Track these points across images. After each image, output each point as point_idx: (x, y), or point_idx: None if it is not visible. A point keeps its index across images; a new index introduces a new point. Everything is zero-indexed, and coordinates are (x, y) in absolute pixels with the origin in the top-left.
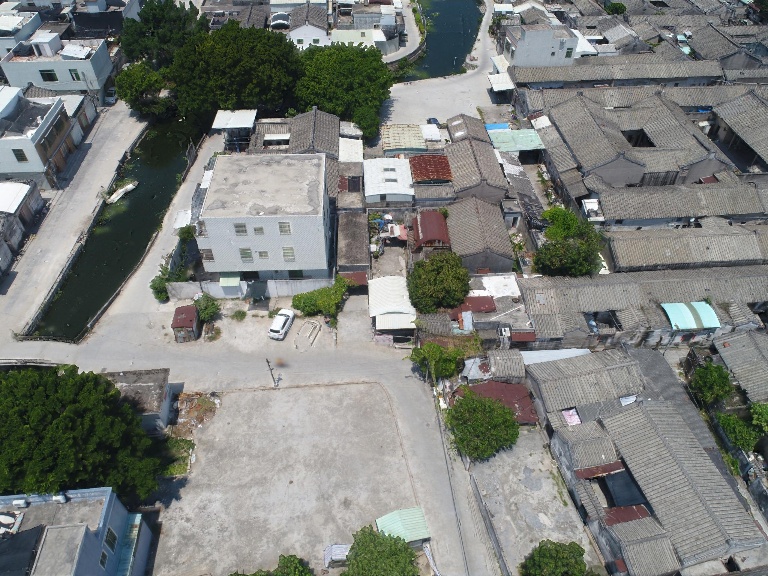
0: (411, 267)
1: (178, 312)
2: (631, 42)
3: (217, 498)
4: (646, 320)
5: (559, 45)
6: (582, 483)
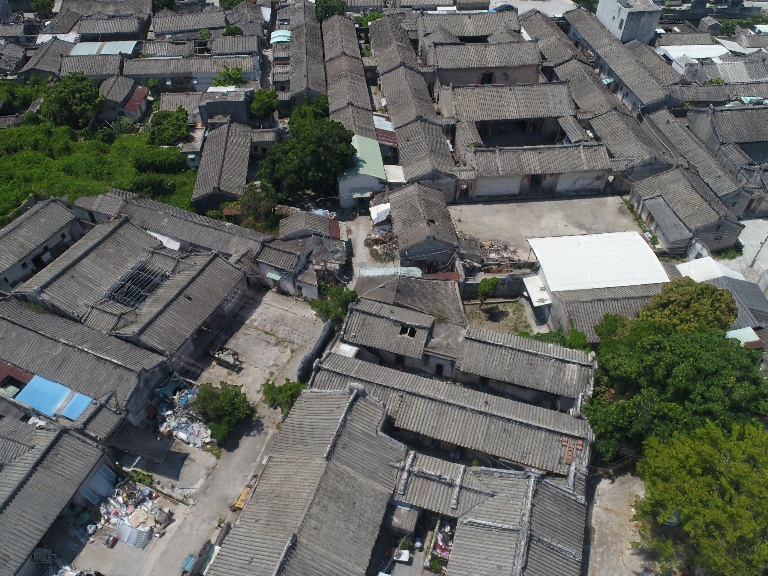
0: None
1: None
2: (695, 64)
3: None
4: None
5: (618, 11)
6: (196, 11)
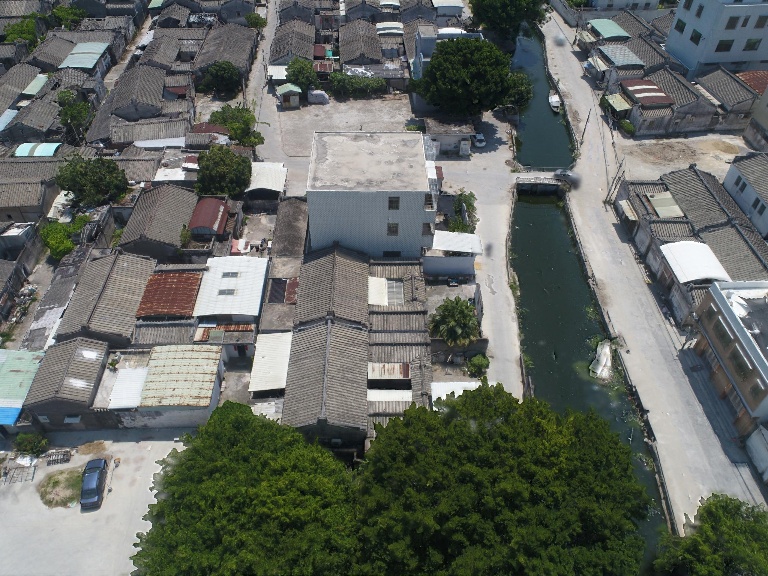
0: (241, 201)
1: (440, 175)
2: None
3: (386, 119)
4: (74, 152)
5: None
6: None
